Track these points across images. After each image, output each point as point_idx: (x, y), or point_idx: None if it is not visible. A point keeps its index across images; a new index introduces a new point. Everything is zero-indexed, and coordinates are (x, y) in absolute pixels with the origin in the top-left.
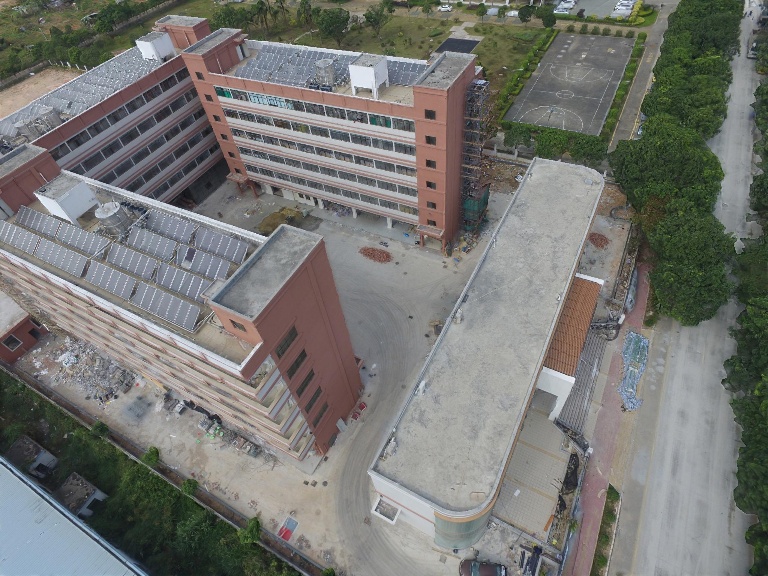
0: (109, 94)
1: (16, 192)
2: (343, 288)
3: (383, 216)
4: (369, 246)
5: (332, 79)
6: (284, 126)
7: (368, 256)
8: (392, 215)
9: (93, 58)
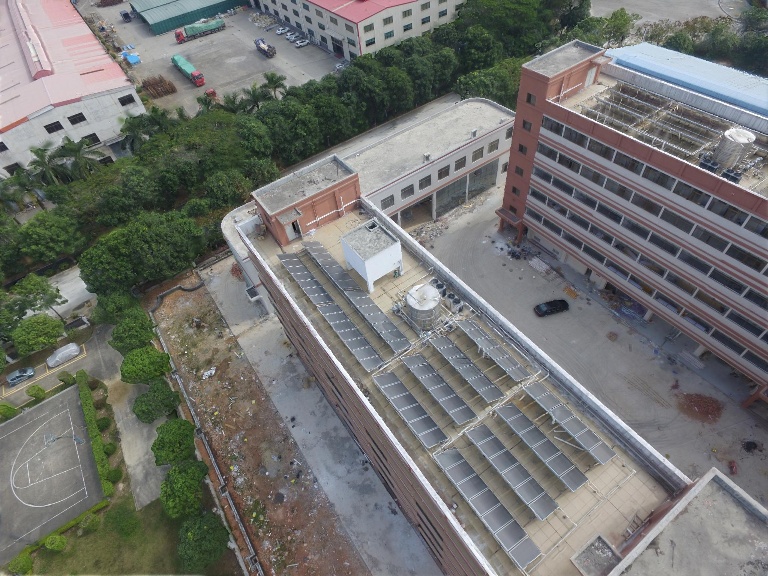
0: None
1: None
2: None
3: None
4: None
5: None
6: None
7: None
8: None
9: None
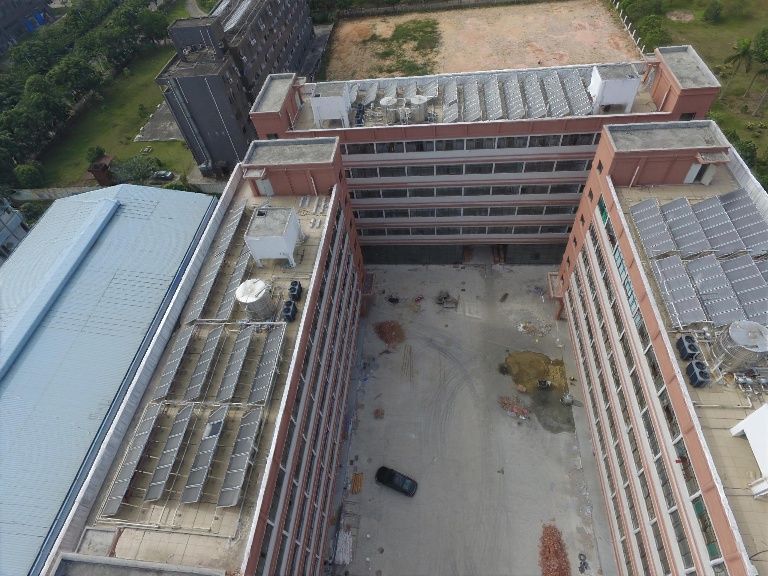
0: (494, 116)
1: (284, 180)
2: (467, 538)
3: (615, 549)
4: (565, 537)
5: (737, 365)
6: (618, 321)
7: (544, 547)
8: (621, 571)
9: (639, 14)
